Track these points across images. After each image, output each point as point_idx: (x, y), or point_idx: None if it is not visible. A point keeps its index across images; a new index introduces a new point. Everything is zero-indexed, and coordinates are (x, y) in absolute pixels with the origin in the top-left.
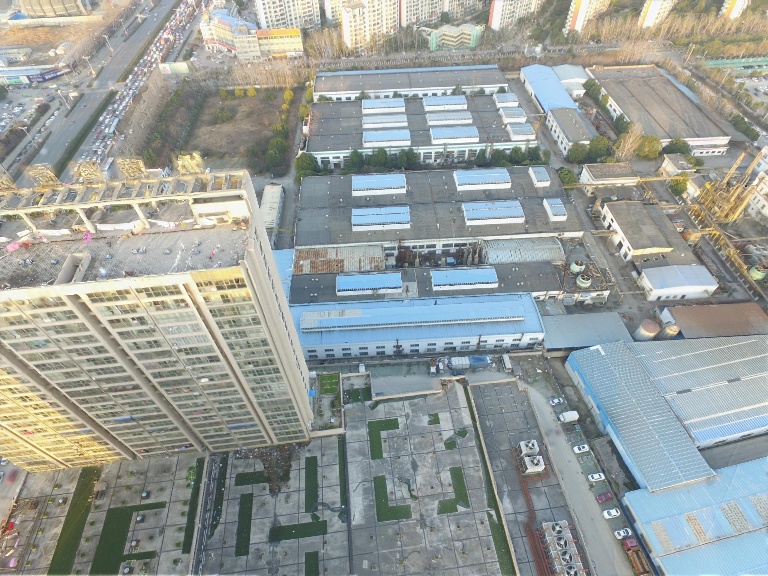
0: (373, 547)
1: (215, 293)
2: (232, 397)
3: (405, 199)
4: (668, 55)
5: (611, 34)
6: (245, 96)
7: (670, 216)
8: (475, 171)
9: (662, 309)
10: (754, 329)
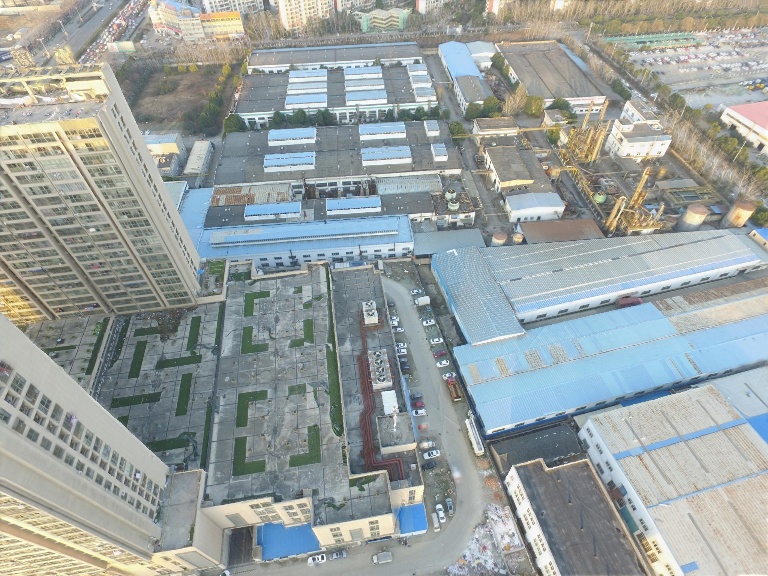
0: (235, 369)
1: (81, 141)
2: (119, 250)
3: (314, 148)
4: (574, 34)
5: (523, 15)
6: (188, 72)
7: (542, 159)
8: (377, 124)
9: (517, 226)
10: (584, 236)
